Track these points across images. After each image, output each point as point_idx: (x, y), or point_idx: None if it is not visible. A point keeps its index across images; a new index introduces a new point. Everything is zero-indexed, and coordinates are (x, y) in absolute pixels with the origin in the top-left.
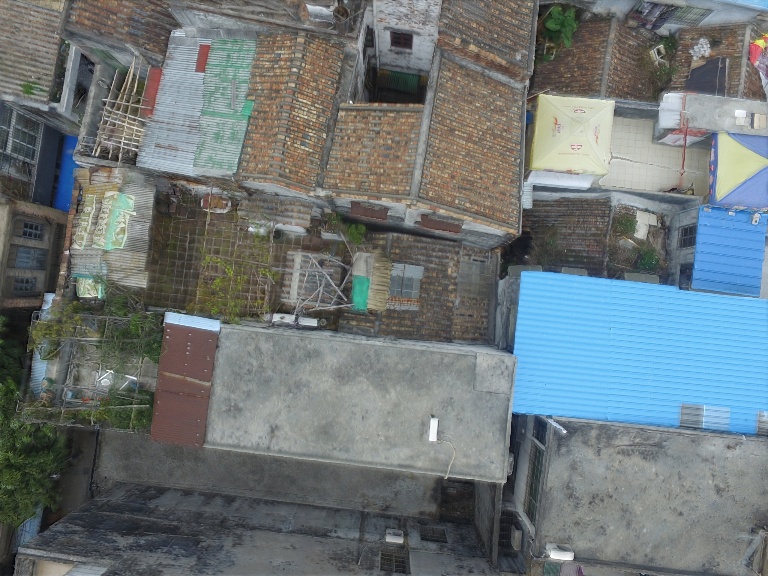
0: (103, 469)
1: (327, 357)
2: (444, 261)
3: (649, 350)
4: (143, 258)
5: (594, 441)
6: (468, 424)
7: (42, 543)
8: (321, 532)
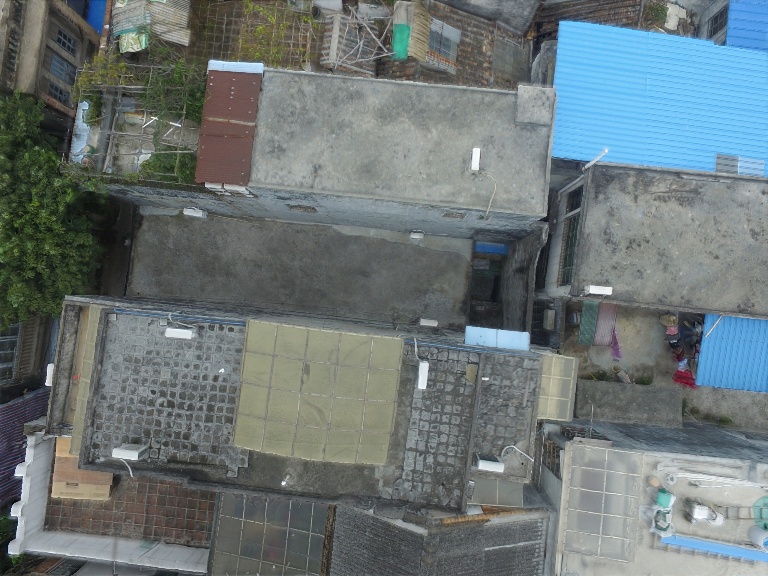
0: (136, 285)
1: (369, 99)
2: (479, 38)
3: (685, 102)
4: (185, 17)
5: (631, 188)
6: (509, 161)
7: (87, 297)
8: (356, 321)
